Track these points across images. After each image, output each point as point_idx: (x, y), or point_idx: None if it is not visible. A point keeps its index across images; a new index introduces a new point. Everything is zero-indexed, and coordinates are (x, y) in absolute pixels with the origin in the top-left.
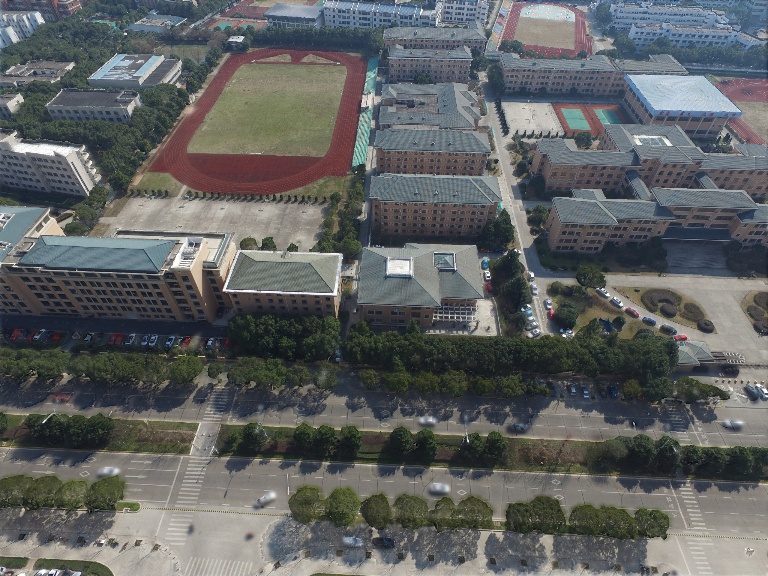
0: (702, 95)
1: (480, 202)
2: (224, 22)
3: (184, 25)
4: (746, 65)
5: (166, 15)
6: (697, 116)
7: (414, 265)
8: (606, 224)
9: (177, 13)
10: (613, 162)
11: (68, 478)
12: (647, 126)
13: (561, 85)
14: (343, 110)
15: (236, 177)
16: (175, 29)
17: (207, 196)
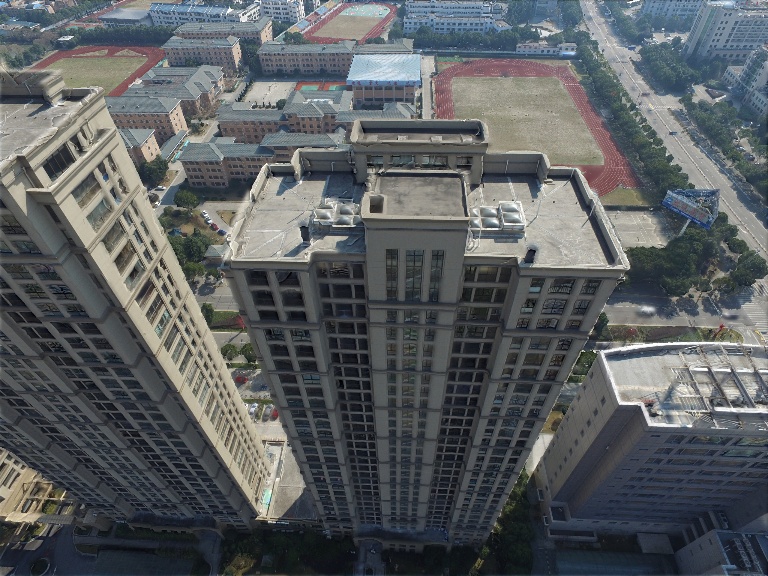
0: (399, 68)
1: None
2: (74, 26)
3: (25, 28)
4: (495, 47)
5: (22, 21)
6: (386, 85)
7: None
8: (212, 160)
9: (34, 19)
10: (265, 118)
11: None
12: (320, 91)
13: (311, 67)
14: (115, 91)
15: None
16: (15, 31)
17: None
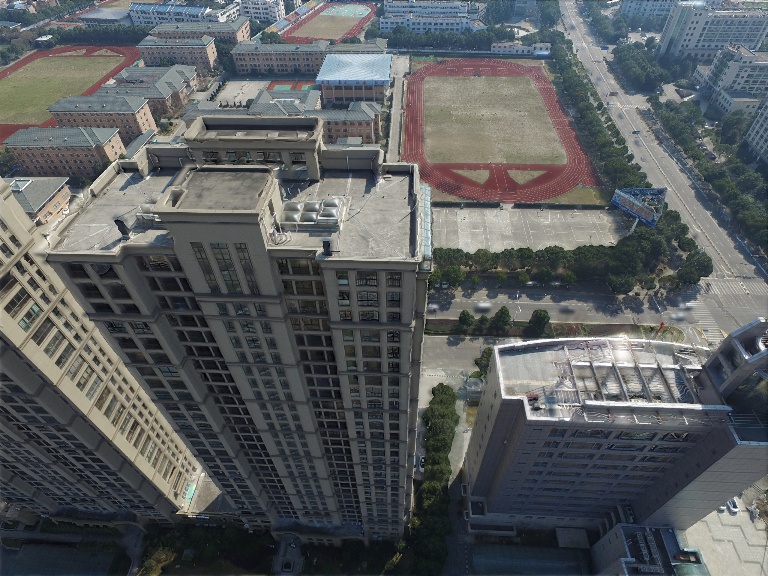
0: (369, 68)
1: (83, 145)
2: (55, 26)
3: None
4: (470, 47)
5: (3, 21)
6: (355, 85)
7: None
8: None
9: (15, 19)
10: None
11: None
12: (287, 91)
13: (285, 66)
14: (89, 90)
15: None
16: None
17: None
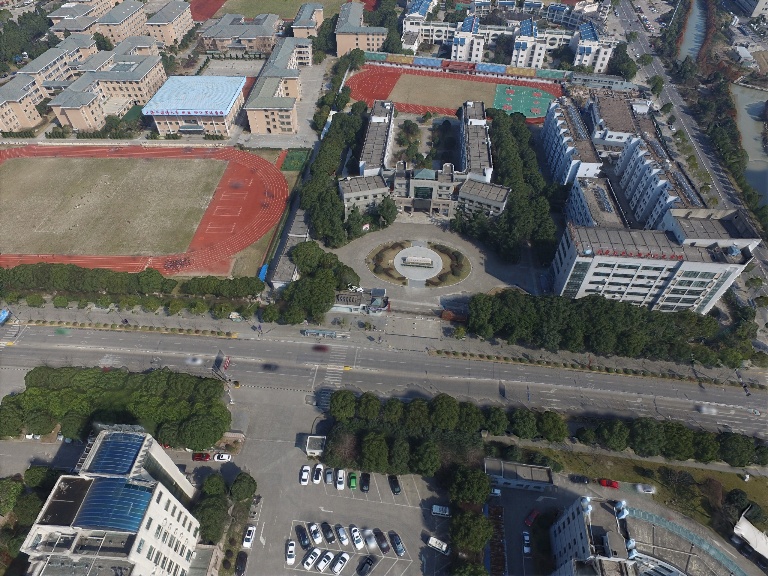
0: (182, 97)
1: None
2: None
3: None
4: None
5: None
6: None
7: (68, 8)
8: None
9: None
10: None
11: (57, 1)
12: None
13: None
14: None
15: (202, 4)
16: None
17: (188, 1)
